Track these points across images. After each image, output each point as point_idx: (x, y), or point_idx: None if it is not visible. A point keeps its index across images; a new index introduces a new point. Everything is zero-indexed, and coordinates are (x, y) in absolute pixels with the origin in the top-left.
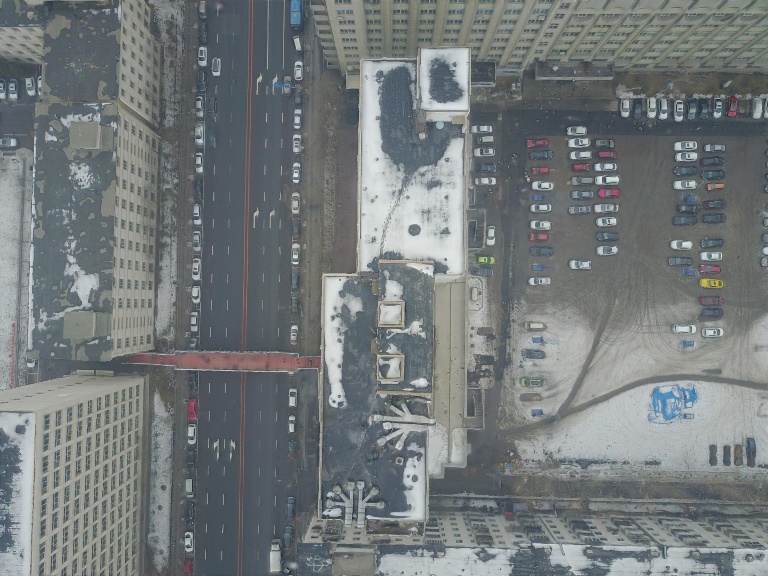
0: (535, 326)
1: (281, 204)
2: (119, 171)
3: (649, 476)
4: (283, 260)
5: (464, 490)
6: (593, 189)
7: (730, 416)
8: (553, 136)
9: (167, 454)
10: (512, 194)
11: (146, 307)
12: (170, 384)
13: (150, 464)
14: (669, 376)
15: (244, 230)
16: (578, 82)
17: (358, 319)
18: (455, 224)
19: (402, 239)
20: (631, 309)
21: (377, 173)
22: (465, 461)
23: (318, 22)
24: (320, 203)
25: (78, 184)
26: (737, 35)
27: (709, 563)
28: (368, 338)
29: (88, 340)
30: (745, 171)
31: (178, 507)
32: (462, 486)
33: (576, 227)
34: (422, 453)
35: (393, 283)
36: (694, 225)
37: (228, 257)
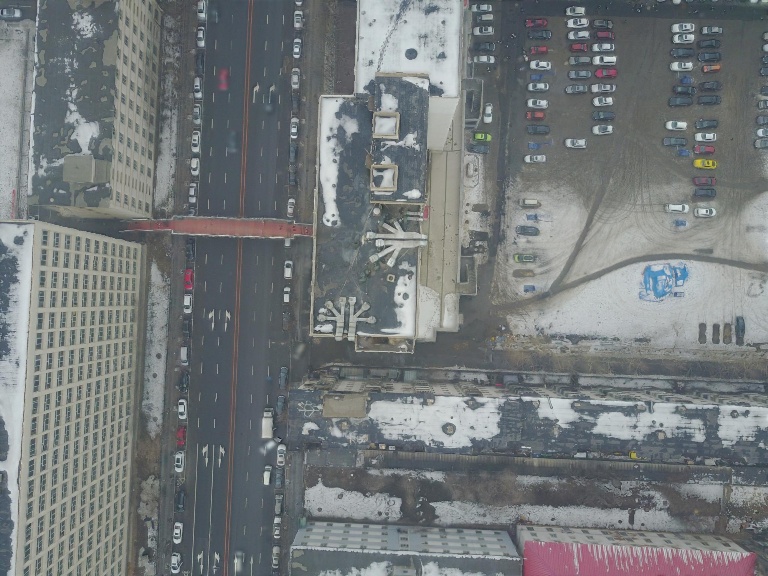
0: (529, 202)
1: (281, 78)
2: (121, 25)
3: (638, 353)
4: (282, 135)
5: (455, 364)
6: (590, 69)
7: (720, 295)
8: (552, 17)
9: (163, 323)
10: (510, 73)
11: (145, 174)
12: (167, 254)
13: (146, 333)
14: (661, 255)
15: (244, 104)
16: None
17: (353, 140)
18: (451, 49)
19: (399, 63)
20: (625, 188)
21: None
22: (457, 325)
23: None
24: (320, 79)
25: (80, 33)
26: None
27: (694, 418)
28: (363, 159)
29: (87, 187)
30: (741, 54)
31: (172, 375)
32: (453, 360)
33: (573, 107)
34: (413, 272)
35: (388, 96)
36: (689, 107)
37: (227, 131)
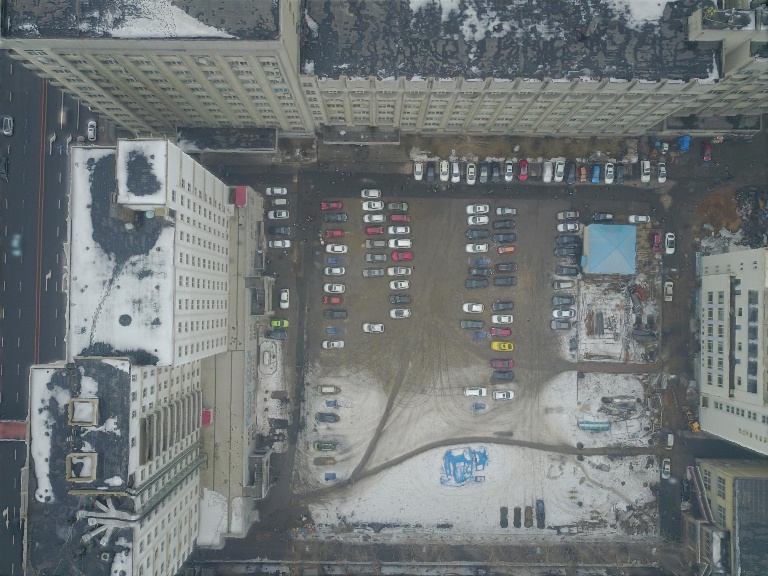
0: (327, 390)
1: None
2: None
3: (441, 539)
4: None
5: (257, 555)
6: (387, 252)
7: (521, 478)
8: (348, 198)
9: None
10: (307, 257)
11: None
12: None
13: None
14: (461, 439)
15: (36, 293)
16: (371, 145)
17: (66, 412)
18: (166, 314)
19: (112, 330)
20: (424, 372)
21: (87, 262)
22: (243, 531)
23: (72, 94)
24: None
25: None
26: (500, 108)
27: None
28: None
29: None
30: (537, 234)
31: None
32: (255, 551)
33: (370, 290)
34: (130, 548)
35: (88, 379)
36: (486, 288)
37: (19, 320)
